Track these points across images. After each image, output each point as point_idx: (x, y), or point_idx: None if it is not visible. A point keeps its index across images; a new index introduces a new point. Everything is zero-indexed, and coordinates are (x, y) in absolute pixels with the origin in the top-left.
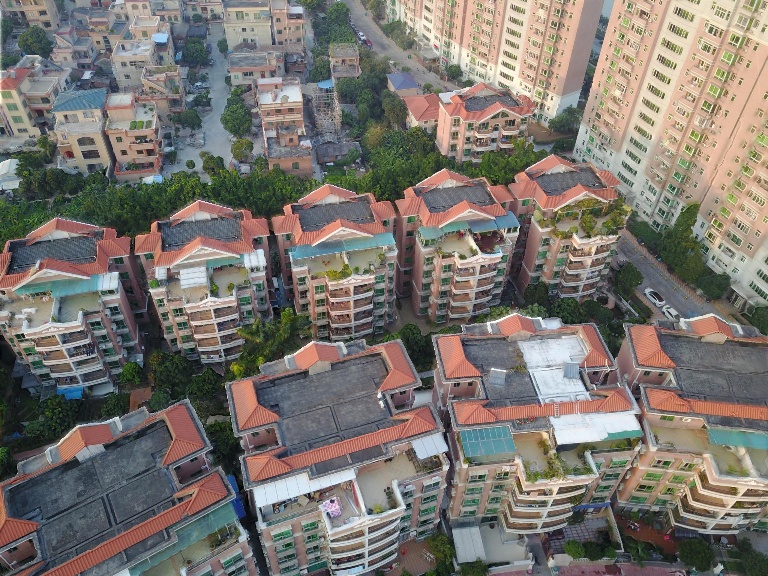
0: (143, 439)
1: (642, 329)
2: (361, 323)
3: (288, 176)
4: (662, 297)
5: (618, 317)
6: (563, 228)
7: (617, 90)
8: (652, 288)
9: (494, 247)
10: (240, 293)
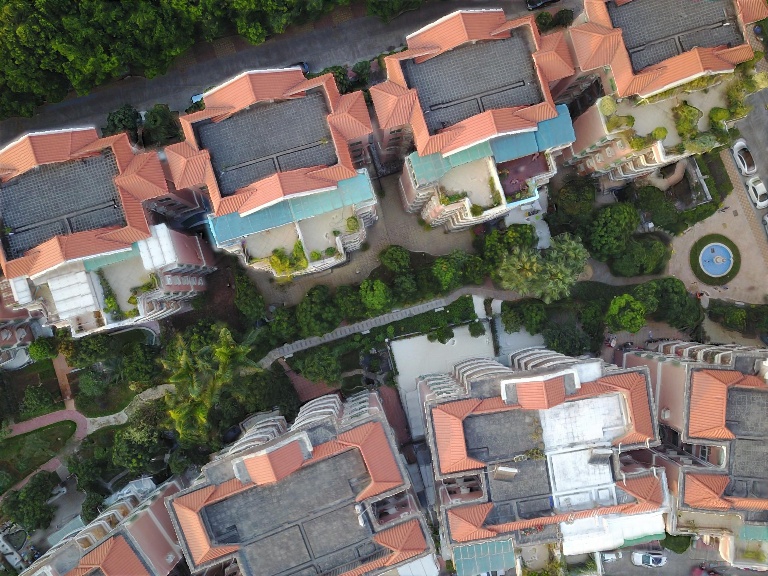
0: None
1: (710, 383)
2: (329, 265)
3: None
4: (755, 161)
5: (682, 200)
6: (644, 118)
7: None
8: (746, 141)
9: (527, 177)
10: (149, 295)
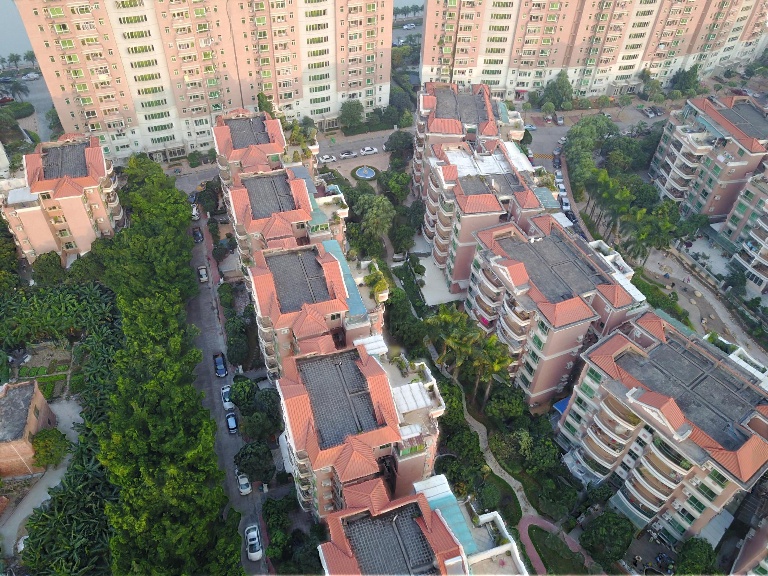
0: (632, 376)
1: (435, 125)
2: None
3: (120, 384)
4: None
5: None
6: None
7: (100, 75)
8: None
9: (324, 191)
10: None
